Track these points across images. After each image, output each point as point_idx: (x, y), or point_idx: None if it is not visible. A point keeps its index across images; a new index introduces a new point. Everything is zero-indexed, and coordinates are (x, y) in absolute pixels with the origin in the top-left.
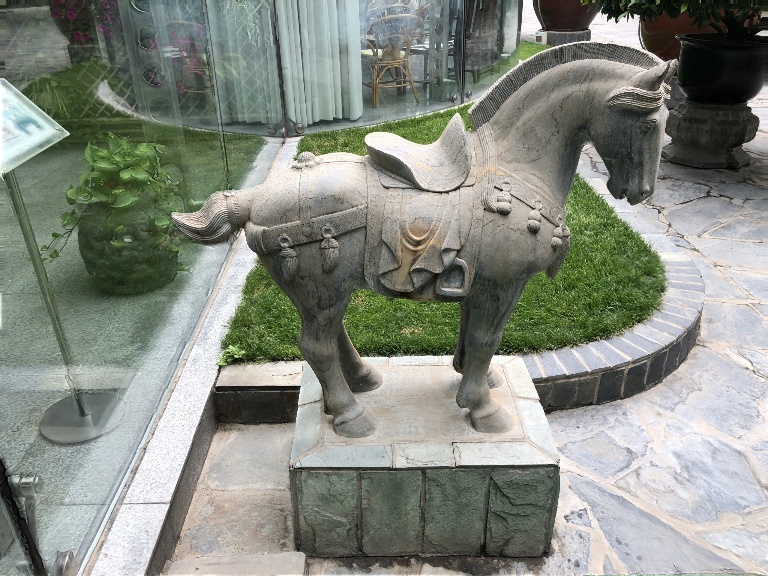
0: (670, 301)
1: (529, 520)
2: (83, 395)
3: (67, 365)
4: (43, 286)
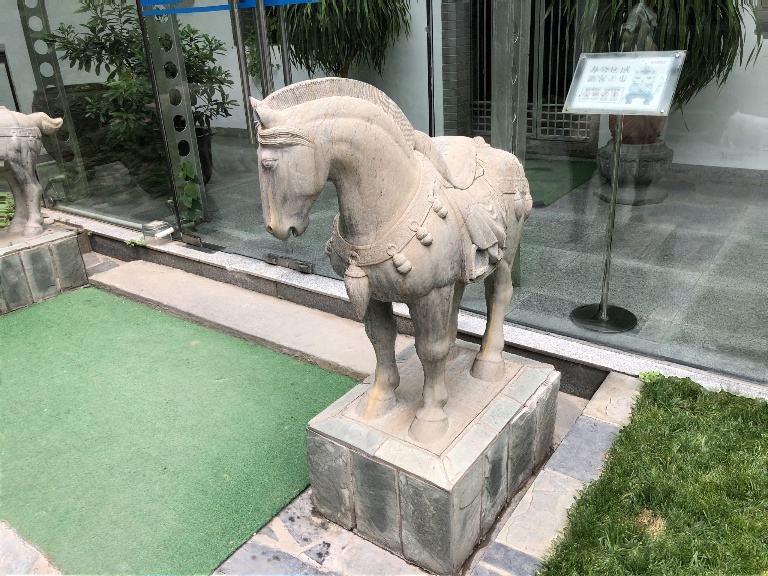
0: None
1: None
2: None
3: (604, 273)
4: None
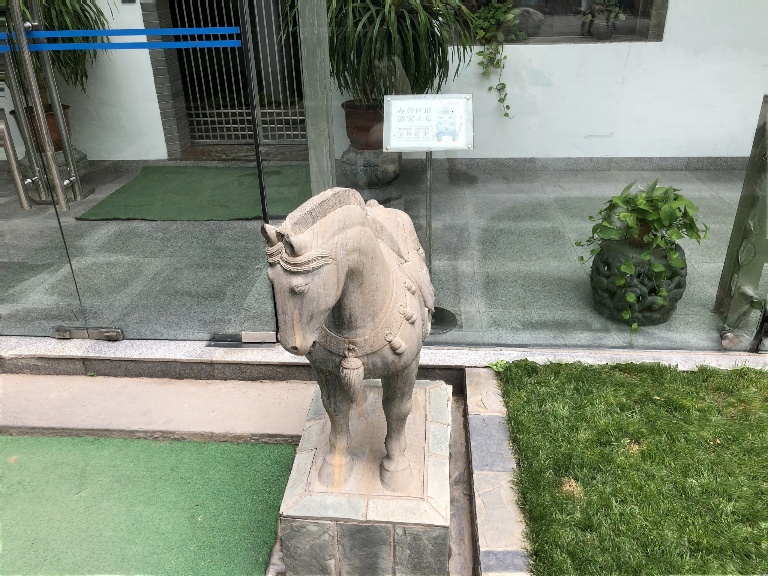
0: None
1: None
2: (452, 316)
3: None
4: None
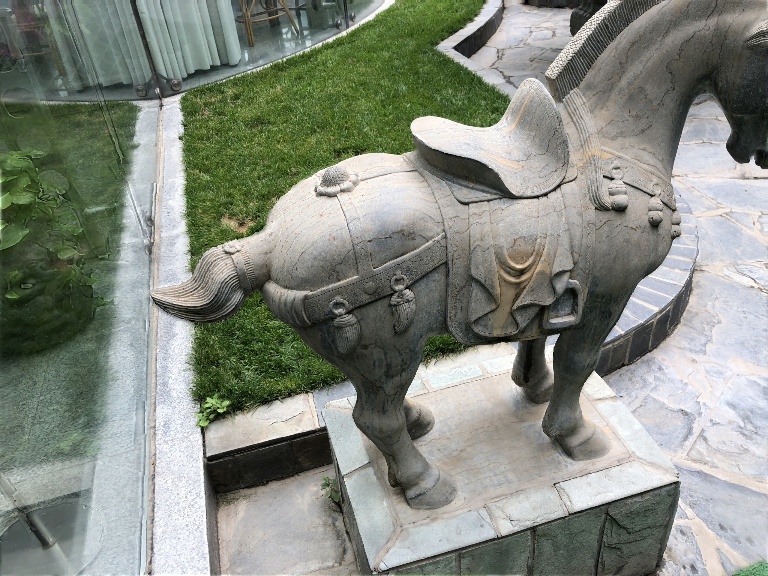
0: None
1: (645, 542)
2: (35, 514)
3: (12, 497)
4: None
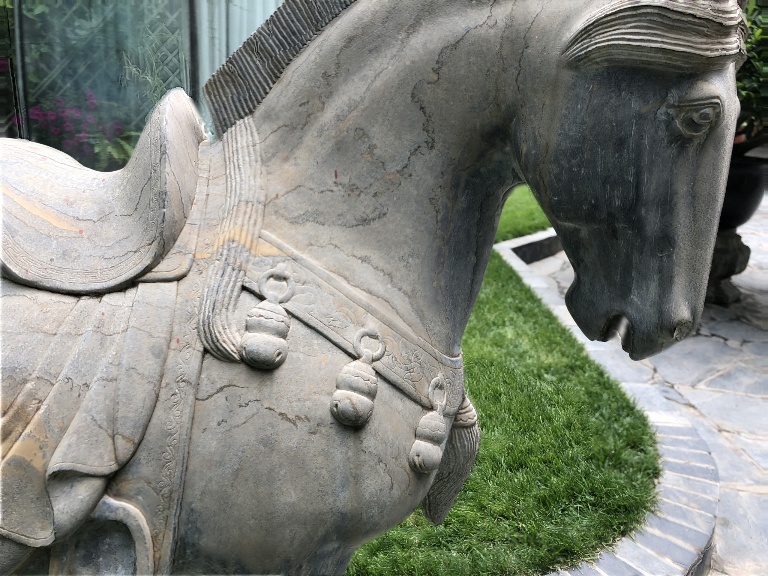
0: (669, 495)
1: None
2: None
3: None
4: None
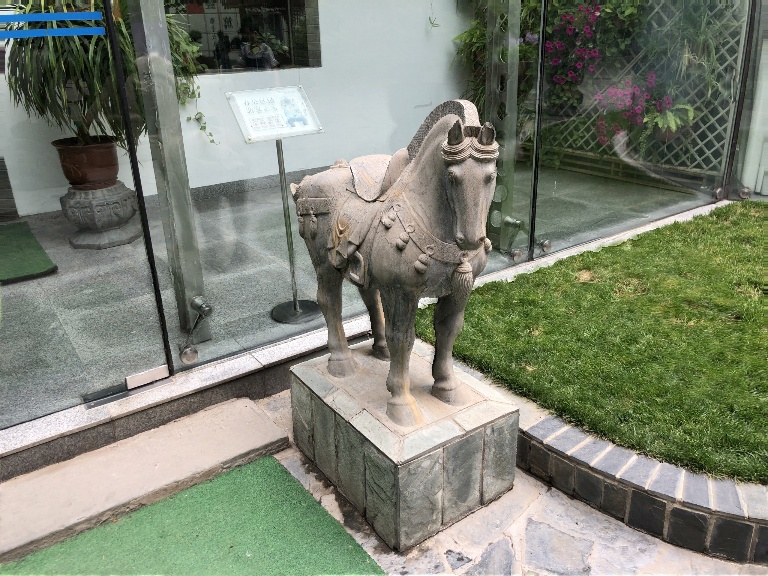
0: None
1: (385, 506)
2: (313, 303)
3: (292, 274)
4: (286, 219)
